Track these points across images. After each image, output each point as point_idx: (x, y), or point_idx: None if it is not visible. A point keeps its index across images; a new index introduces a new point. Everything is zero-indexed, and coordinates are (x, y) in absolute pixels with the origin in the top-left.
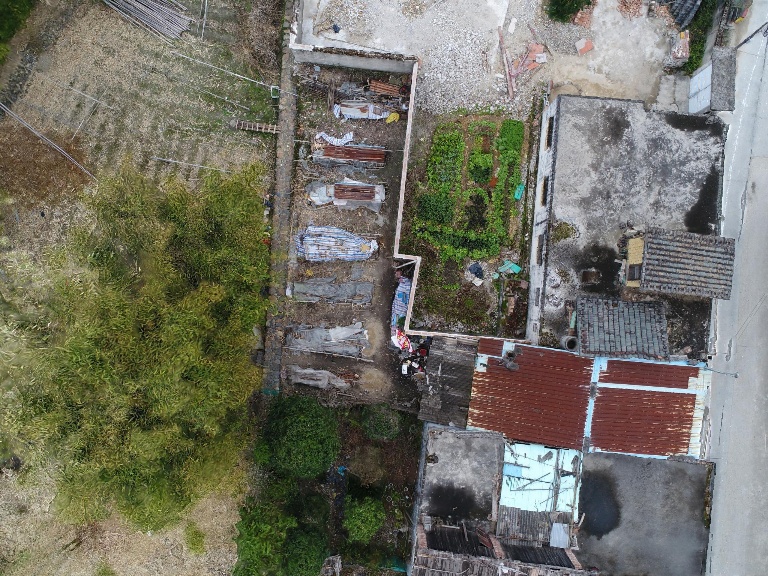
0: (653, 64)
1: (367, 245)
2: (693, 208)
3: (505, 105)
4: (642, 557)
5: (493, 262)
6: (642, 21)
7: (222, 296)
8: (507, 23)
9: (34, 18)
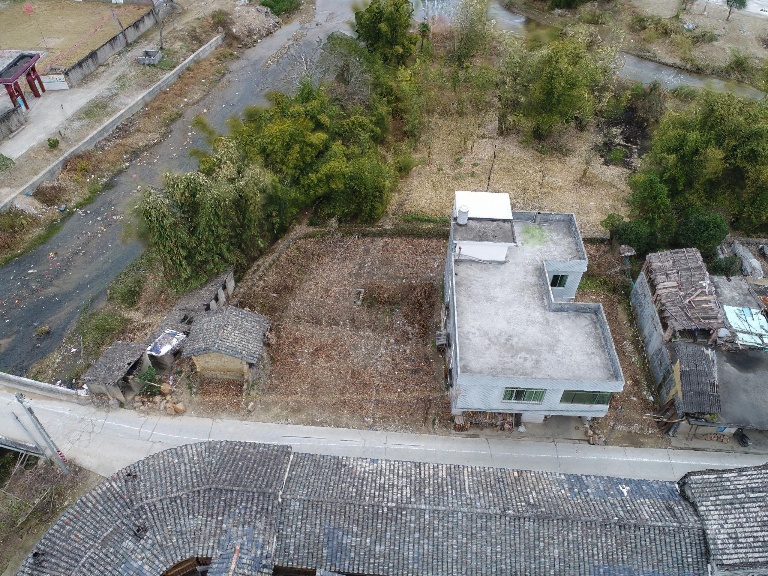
0: None
1: None
2: None
3: None
4: (726, 387)
5: None
6: None
7: None
8: None
9: None
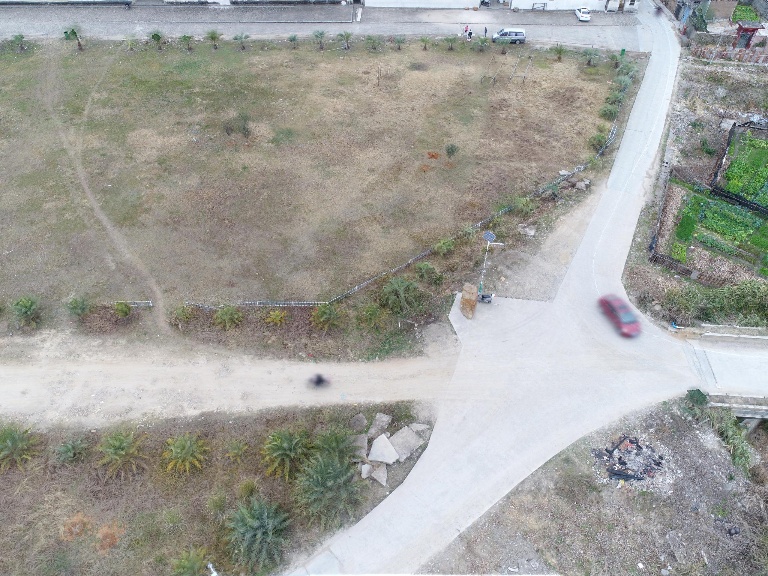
0: None
1: None
2: None
3: None
4: None
5: None
6: None
7: None
8: None
9: None
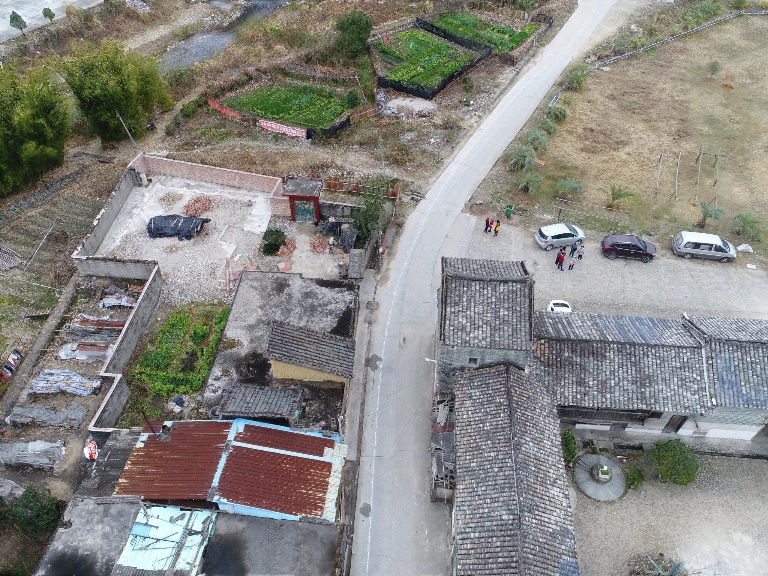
0: (332, 276)
1: (91, 384)
2: (332, 330)
3: (225, 298)
4: None
5: (195, 395)
6: (326, 256)
7: None
8: (234, 256)
9: None
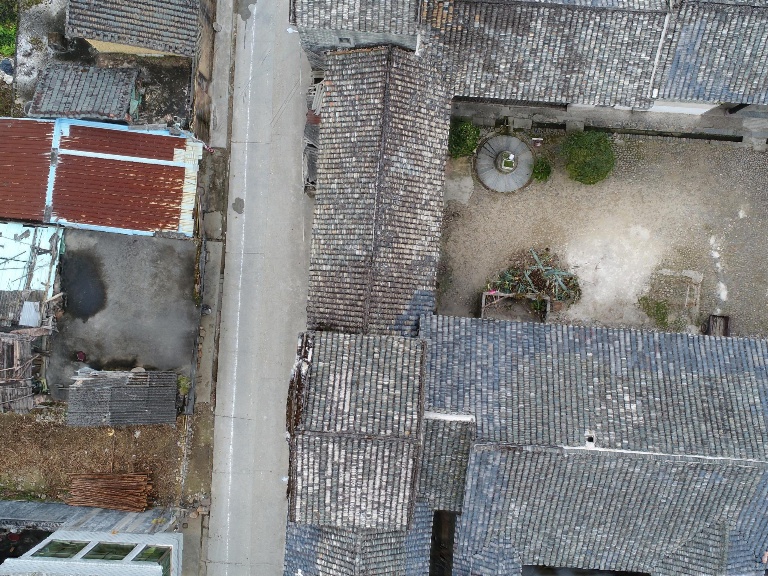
0: None
1: None
2: None
3: None
4: (130, 340)
5: None
6: None
7: None
8: None
9: None
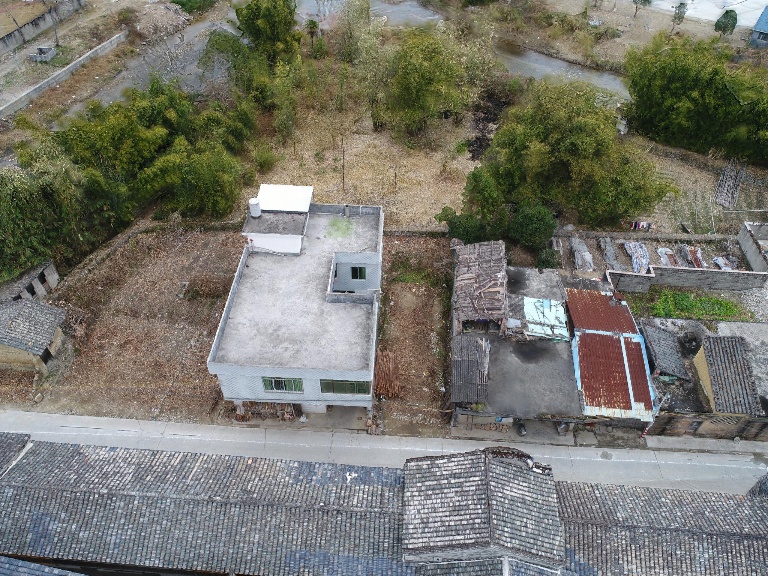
0: None
1: None
2: None
3: None
4: (504, 377)
5: None
6: None
7: (613, 172)
8: None
9: (698, 155)
